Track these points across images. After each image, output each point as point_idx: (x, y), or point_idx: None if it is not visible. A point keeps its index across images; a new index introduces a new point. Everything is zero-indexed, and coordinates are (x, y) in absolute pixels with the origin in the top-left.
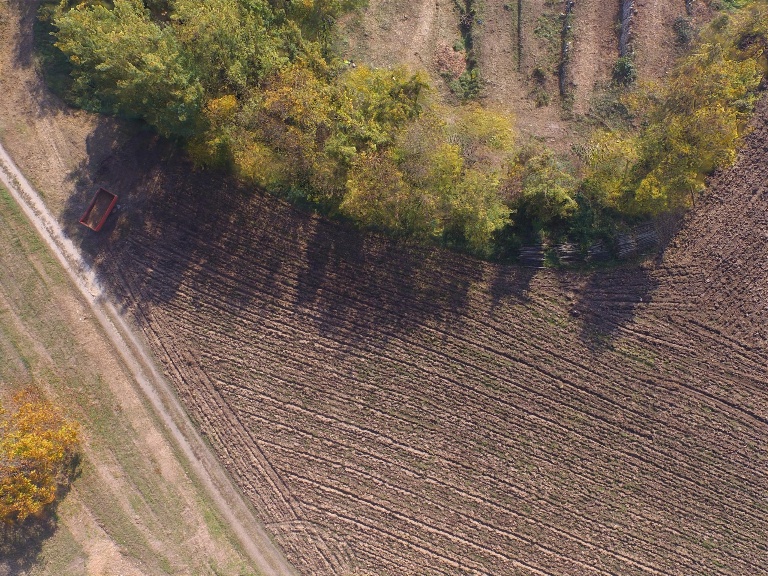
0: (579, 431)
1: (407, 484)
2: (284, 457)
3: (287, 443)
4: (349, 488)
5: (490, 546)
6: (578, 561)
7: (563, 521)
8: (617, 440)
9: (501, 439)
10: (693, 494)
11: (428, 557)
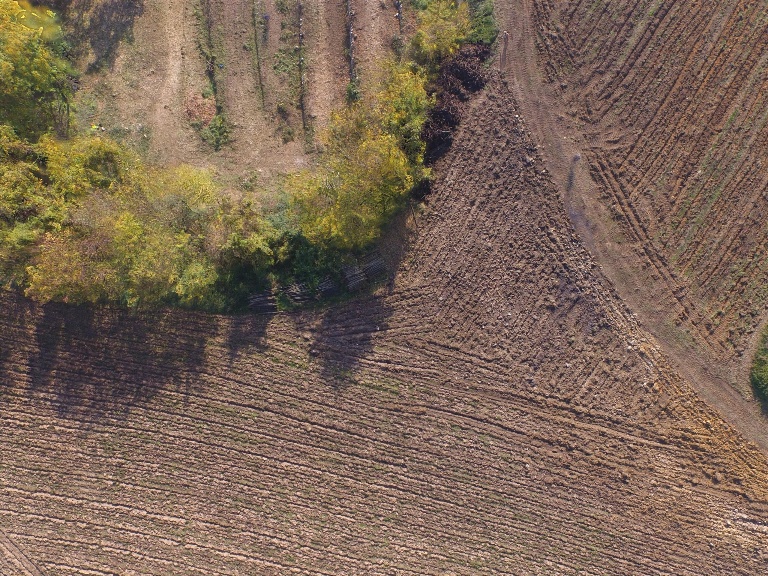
0: (332, 471)
1: (166, 554)
2: (39, 547)
3: (40, 532)
4: (109, 567)
5: None
6: None
7: (328, 565)
8: (372, 474)
9: (256, 492)
10: (454, 516)
11: None
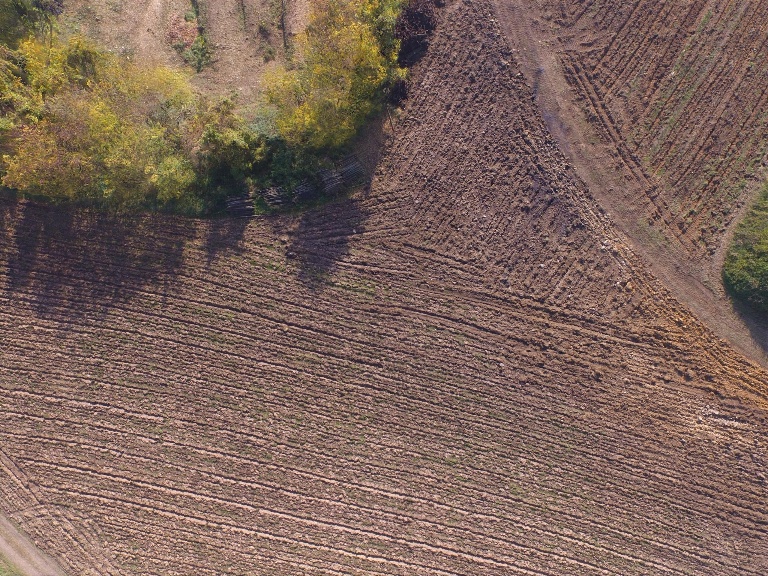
0: (309, 371)
1: (144, 451)
2: (18, 444)
3: (19, 430)
4: (87, 464)
5: (235, 499)
6: (324, 499)
7: (304, 462)
8: (348, 373)
9: (233, 391)
10: (429, 414)
11: (175, 520)
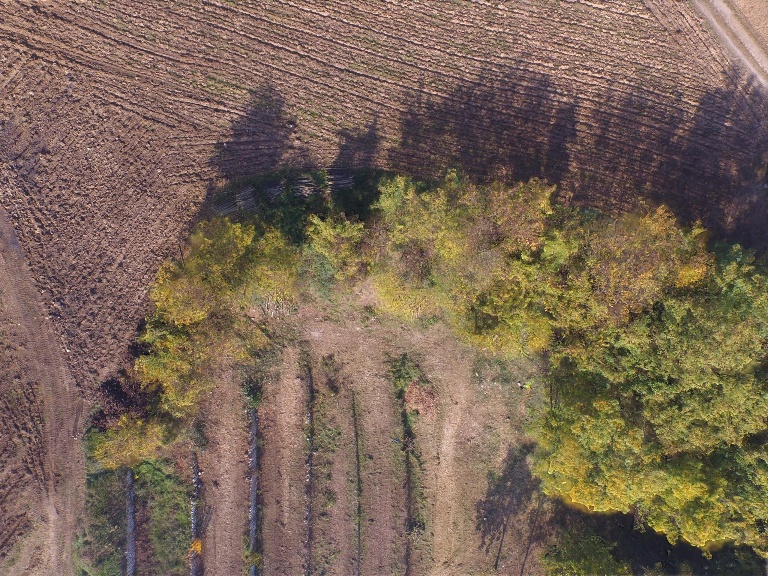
0: (277, 3)
1: None
2: None
3: None
4: None
5: None
6: None
7: None
8: None
9: None
10: None
11: None
